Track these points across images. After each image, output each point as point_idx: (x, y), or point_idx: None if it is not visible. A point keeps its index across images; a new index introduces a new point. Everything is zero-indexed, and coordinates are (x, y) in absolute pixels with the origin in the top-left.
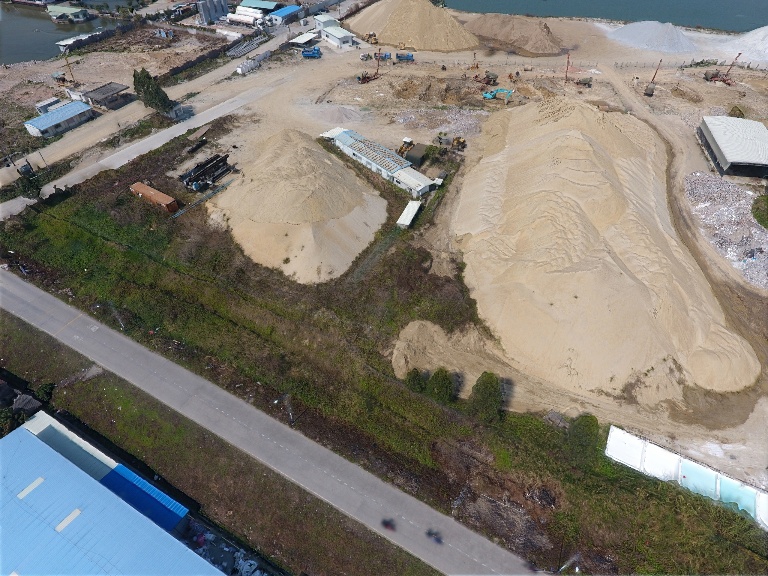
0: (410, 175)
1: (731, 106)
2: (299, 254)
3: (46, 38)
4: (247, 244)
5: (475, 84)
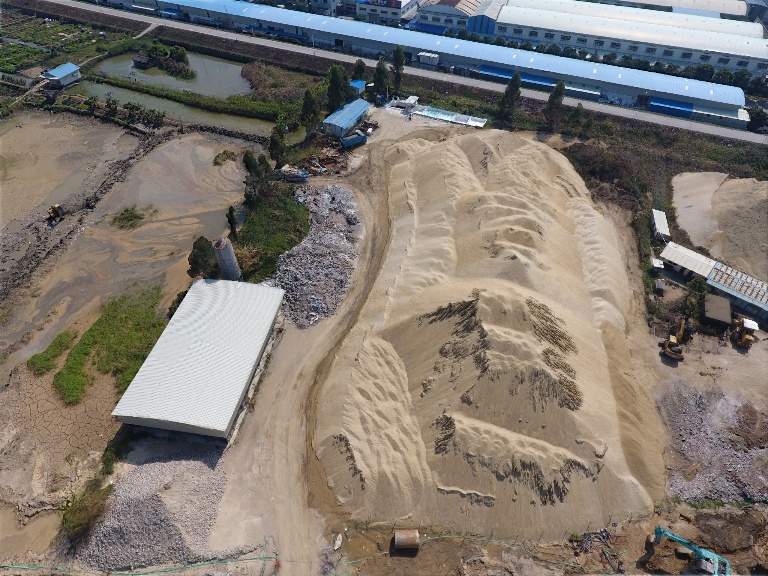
0: (695, 259)
1: None
2: None
3: None
4: None
5: None
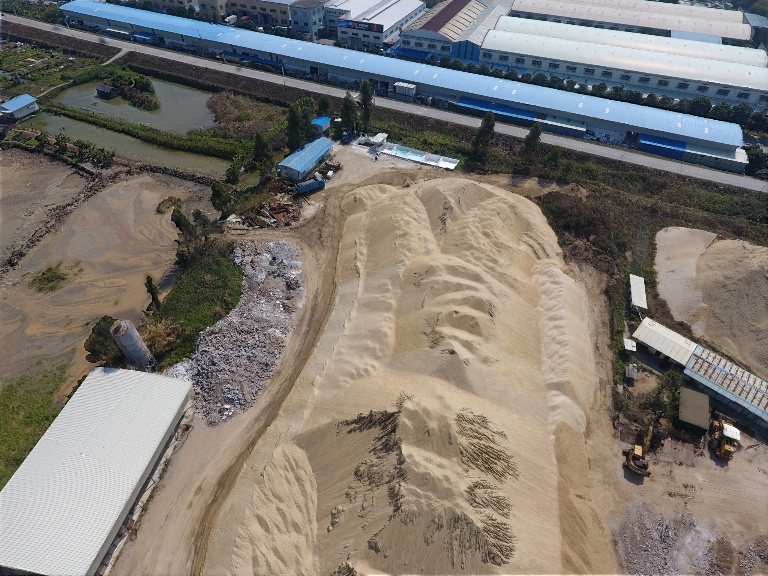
0: (672, 341)
1: None
2: None
3: None
4: None
5: None
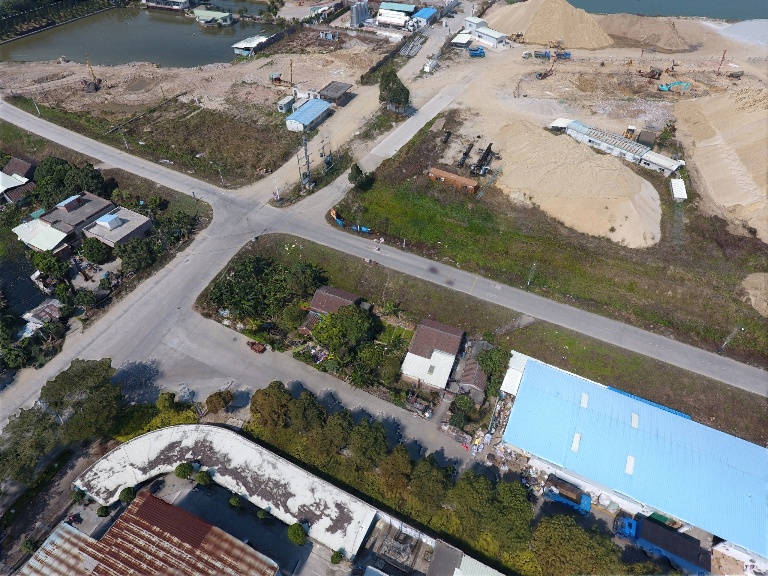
0: (658, 157)
1: None
2: (624, 223)
3: (208, 41)
4: (565, 217)
5: (640, 78)
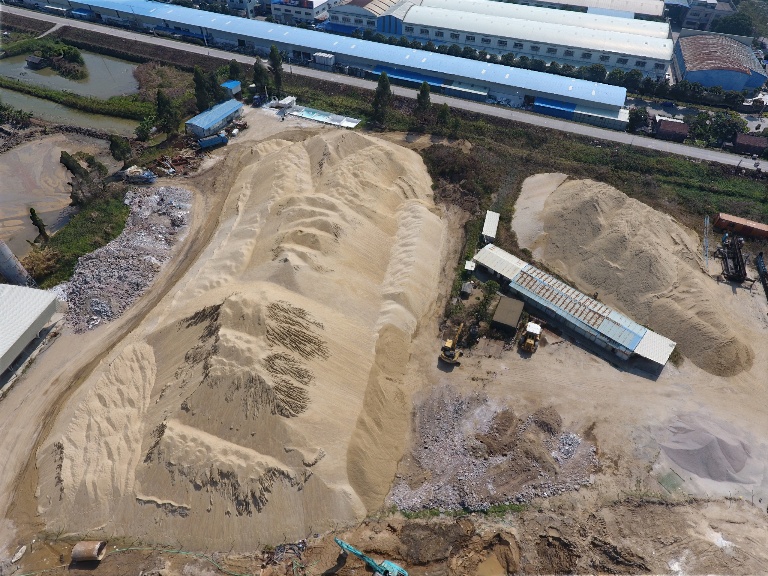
0: (506, 261)
1: None
2: None
3: None
4: None
5: None
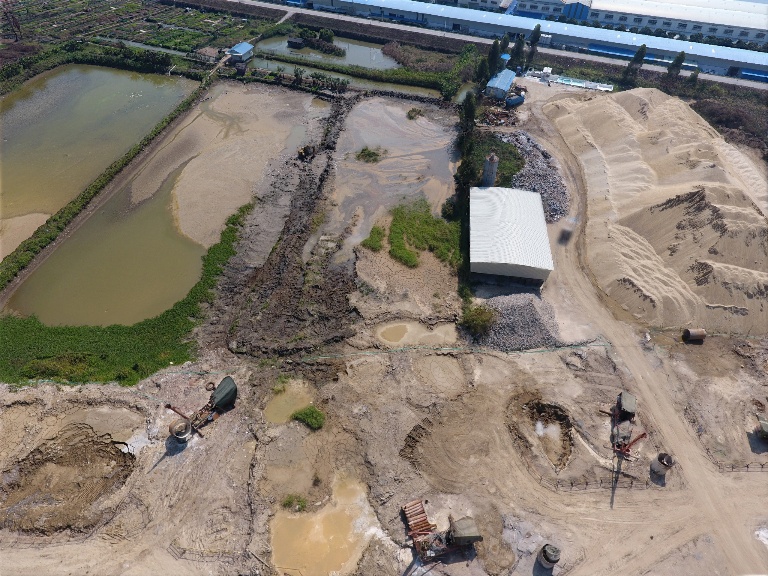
0: None
1: (458, 384)
2: None
3: None
4: None
5: None
